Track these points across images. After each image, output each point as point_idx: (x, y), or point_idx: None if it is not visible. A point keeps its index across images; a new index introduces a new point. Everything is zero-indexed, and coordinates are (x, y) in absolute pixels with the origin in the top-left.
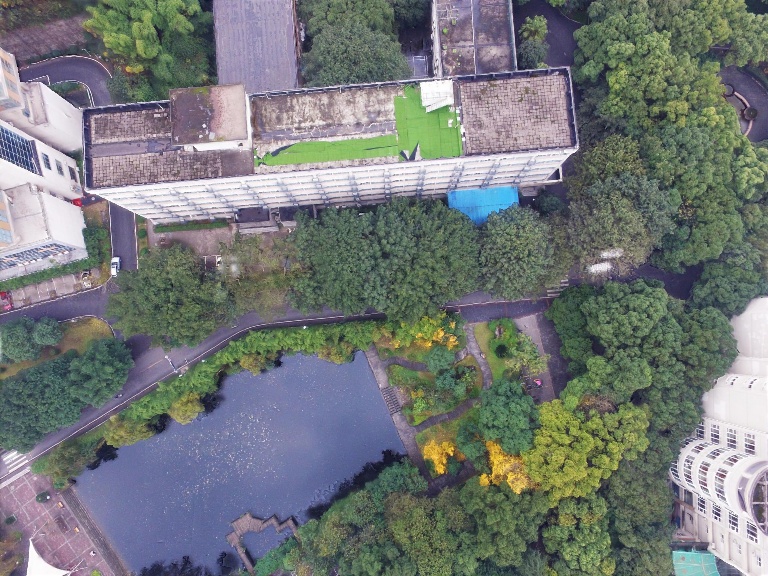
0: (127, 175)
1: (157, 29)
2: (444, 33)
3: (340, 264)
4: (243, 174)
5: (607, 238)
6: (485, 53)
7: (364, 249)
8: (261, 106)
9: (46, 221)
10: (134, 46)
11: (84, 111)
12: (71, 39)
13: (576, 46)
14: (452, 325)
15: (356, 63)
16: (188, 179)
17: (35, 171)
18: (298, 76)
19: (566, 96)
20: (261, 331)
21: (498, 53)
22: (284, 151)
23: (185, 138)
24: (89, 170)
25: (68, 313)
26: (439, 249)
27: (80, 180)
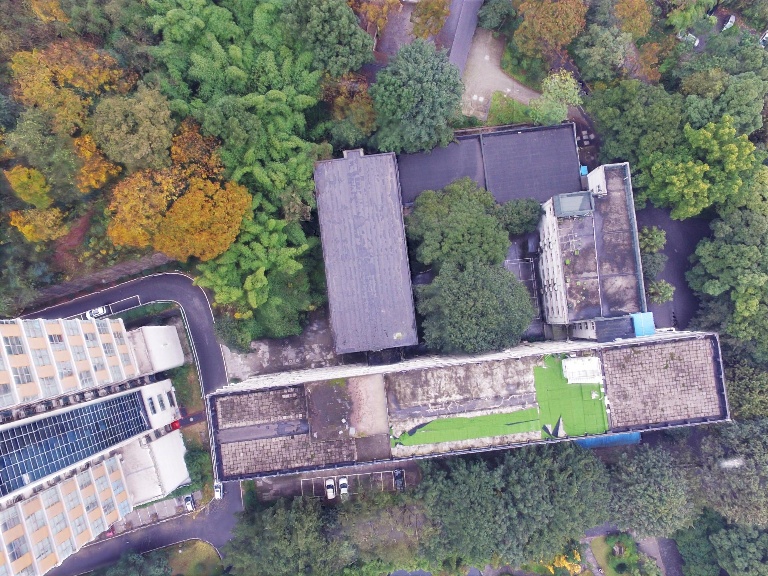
0: (258, 462)
1: (265, 272)
2: (566, 264)
3: (476, 530)
4: (380, 456)
5: (754, 501)
6: (610, 285)
7: (500, 513)
8: (394, 381)
9: (159, 476)
10: (244, 294)
11: (210, 397)
12: (162, 260)
13: (692, 250)
14: (578, 558)
15: (483, 314)
16: (323, 464)
17: (144, 424)
18: (415, 316)
19: (713, 361)
20: (377, 559)
21: (624, 284)
22: (421, 429)
23: (324, 434)
24: (218, 458)
25: (171, 537)
26: (576, 507)
27: (177, 400)
